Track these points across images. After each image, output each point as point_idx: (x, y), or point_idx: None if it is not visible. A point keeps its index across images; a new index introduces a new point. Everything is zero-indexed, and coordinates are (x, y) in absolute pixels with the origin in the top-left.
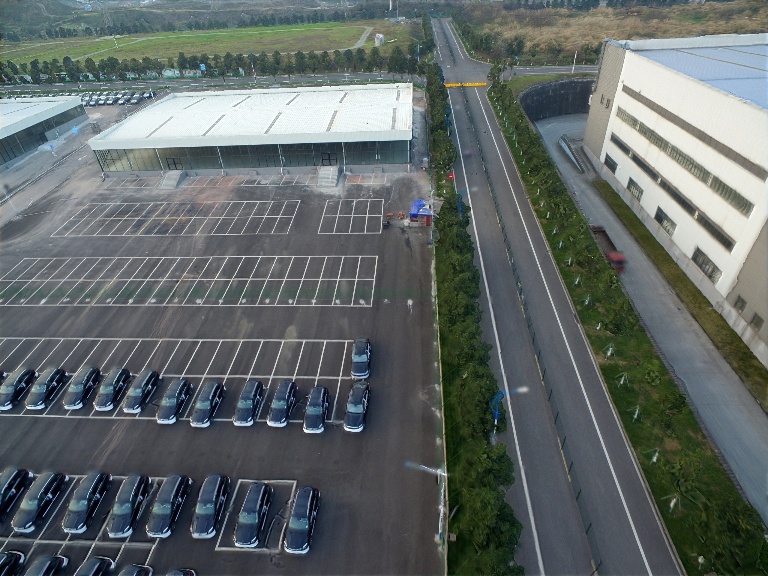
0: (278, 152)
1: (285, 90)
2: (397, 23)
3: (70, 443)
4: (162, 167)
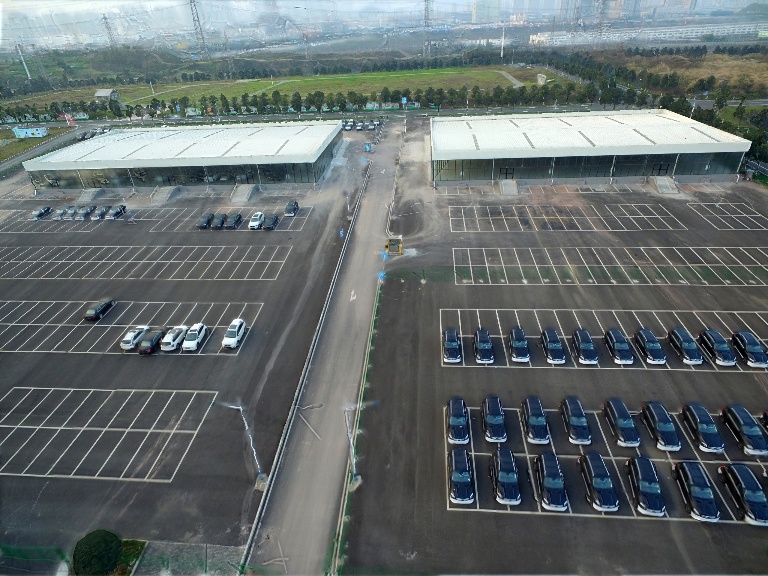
0: (611, 163)
1: (540, 115)
2: (523, 68)
3: (732, 391)
4: (492, 177)
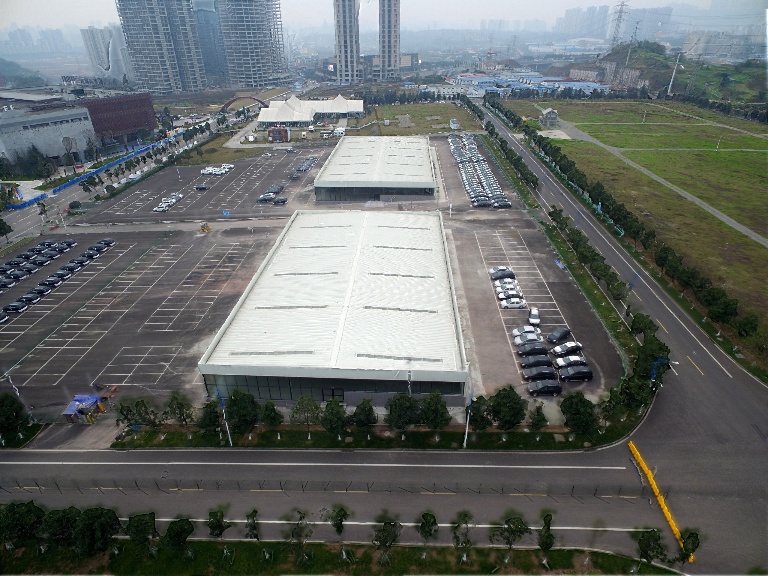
0: None
1: None
2: None
3: (7, 299)
4: None
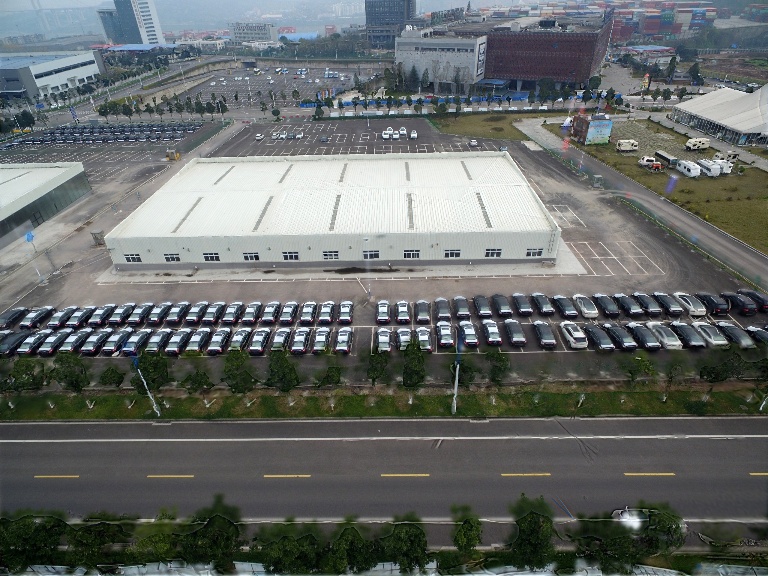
0: None
1: None
2: None
3: None
4: None
